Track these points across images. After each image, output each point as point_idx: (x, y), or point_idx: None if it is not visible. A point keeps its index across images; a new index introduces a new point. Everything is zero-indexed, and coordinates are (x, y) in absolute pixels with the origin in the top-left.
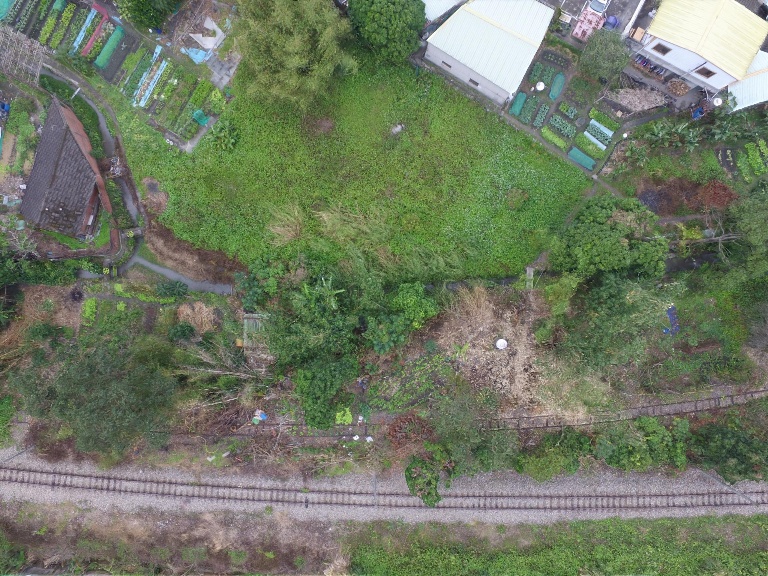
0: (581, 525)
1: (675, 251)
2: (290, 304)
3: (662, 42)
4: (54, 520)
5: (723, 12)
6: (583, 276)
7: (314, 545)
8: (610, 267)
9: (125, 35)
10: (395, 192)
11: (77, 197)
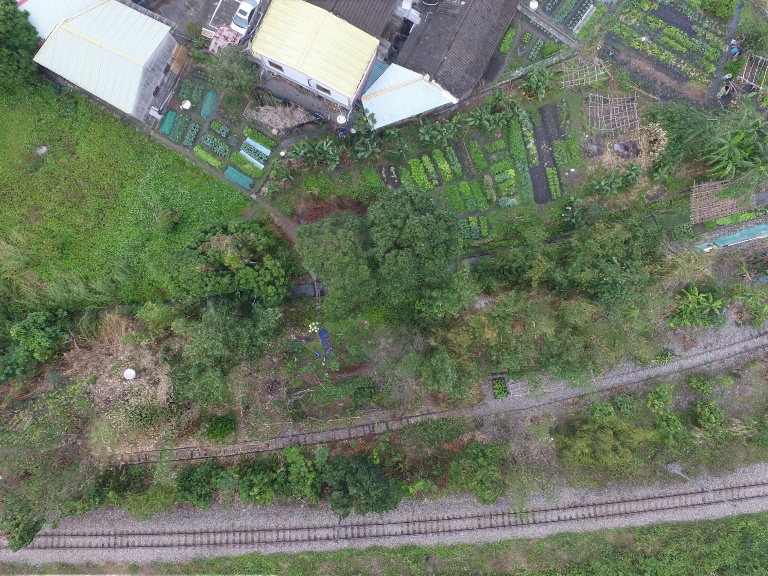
0: (218, 562)
1: None
2: None
3: (269, 59)
4: None
5: (324, 28)
6: (190, 303)
7: None
8: (203, 294)
9: None
10: (41, 216)
11: None
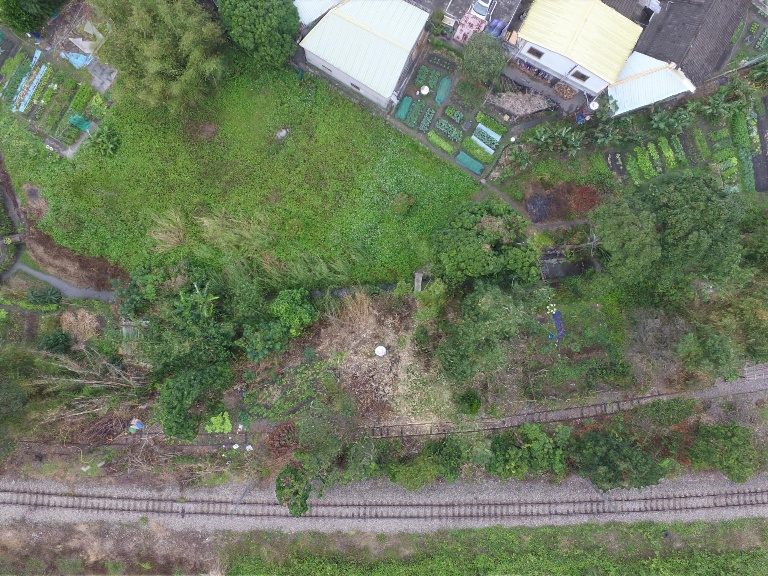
0: (462, 534)
1: (565, 256)
2: None
3: (533, 46)
4: None
5: (592, 15)
6: (455, 282)
7: (191, 556)
8: (477, 273)
9: (3, 40)
10: (280, 197)
11: None
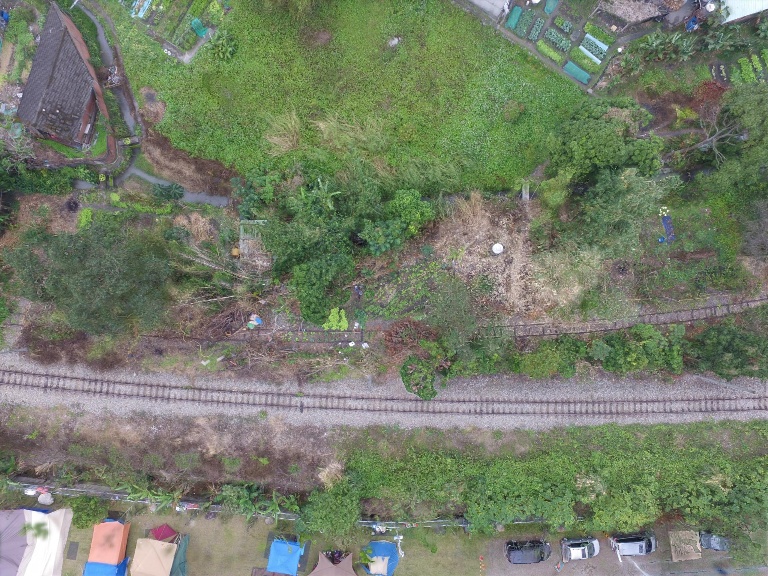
0: (578, 431)
1: (670, 165)
2: (286, 213)
3: None
4: (46, 424)
5: None
6: (578, 174)
7: (309, 451)
8: (605, 161)
9: None
10: (392, 104)
11: (74, 100)
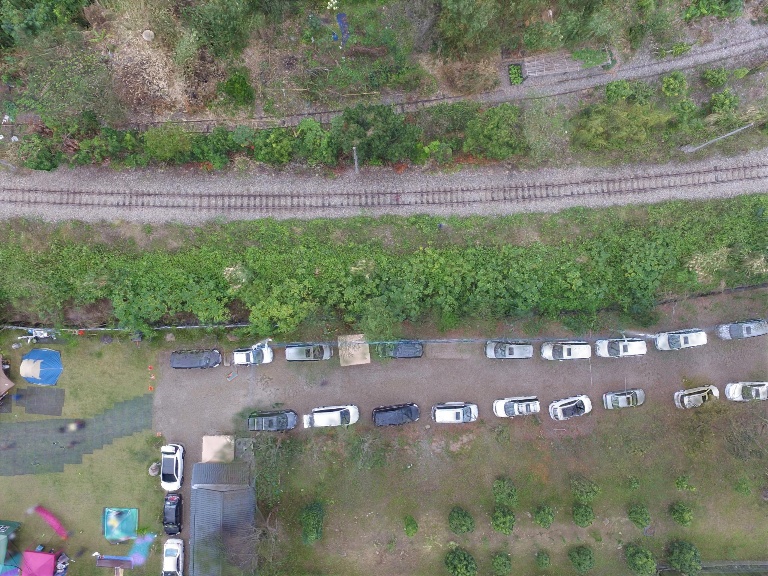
0: (233, 226)
1: None
2: None
3: None
4: None
5: None
6: None
7: None
8: None
9: None
10: None
11: None
